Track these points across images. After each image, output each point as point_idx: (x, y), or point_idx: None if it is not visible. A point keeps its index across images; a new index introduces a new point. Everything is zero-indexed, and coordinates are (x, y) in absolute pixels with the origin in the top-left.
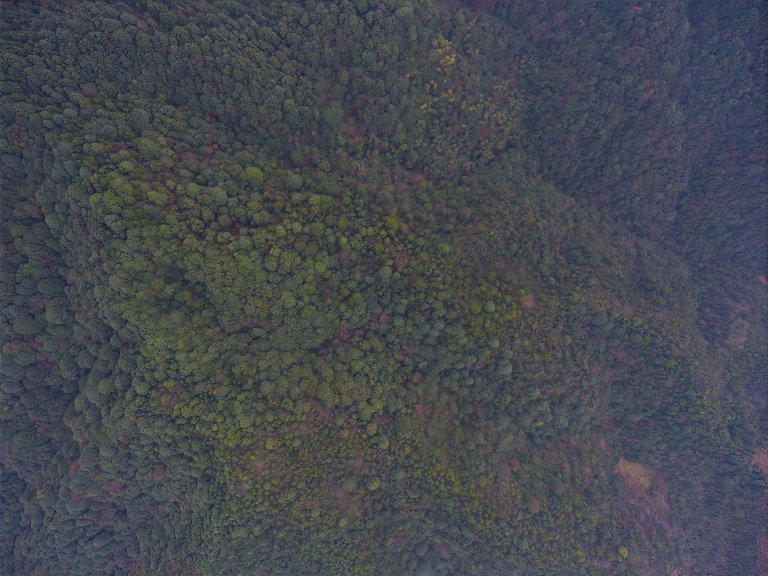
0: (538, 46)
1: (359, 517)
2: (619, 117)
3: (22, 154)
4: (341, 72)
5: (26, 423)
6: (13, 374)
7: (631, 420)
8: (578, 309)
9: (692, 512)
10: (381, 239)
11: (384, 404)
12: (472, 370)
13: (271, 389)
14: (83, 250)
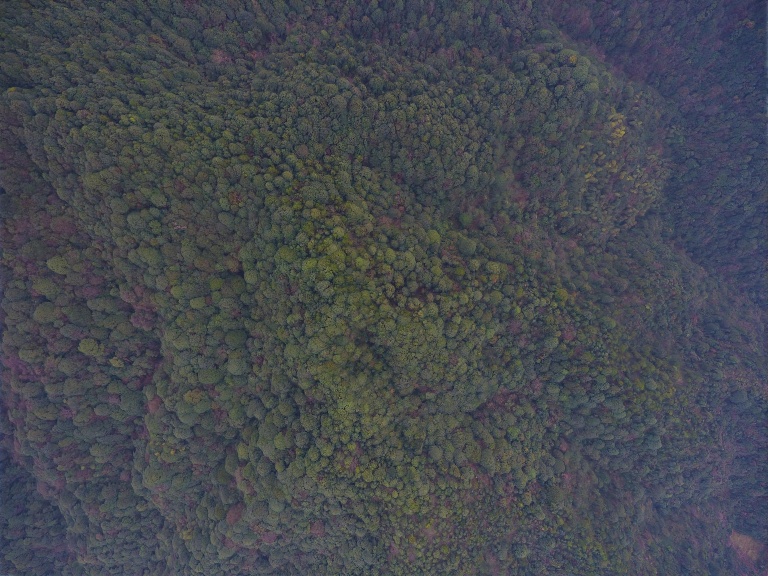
0: (685, 116)
1: None
2: None
3: (237, 212)
4: (518, 139)
5: (185, 466)
6: (190, 422)
7: (750, 495)
8: (721, 386)
9: None
10: (552, 310)
11: (537, 473)
12: (617, 442)
13: (441, 455)
14: (281, 309)
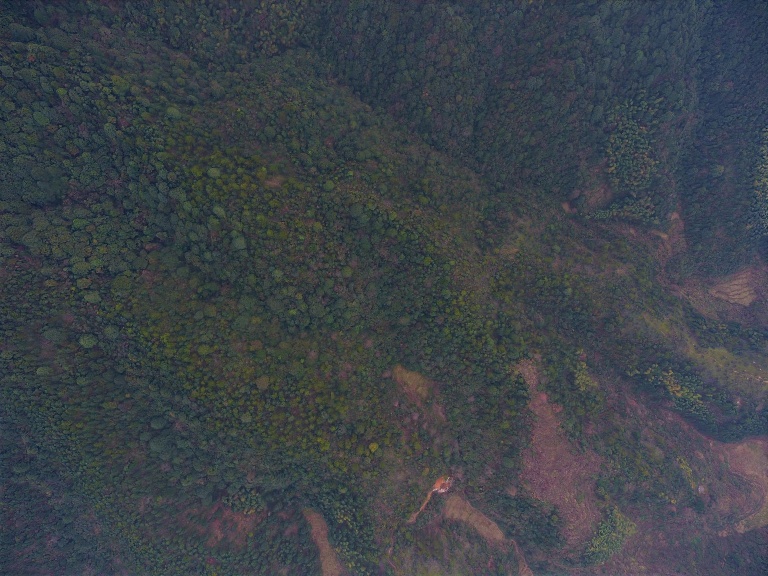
0: None
1: (68, 372)
2: (396, 16)
3: None
4: None
5: None
6: None
7: (401, 323)
8: (330, 196)
9: (466, 424)
10: (104, 96)
11: (104, 263)
12: (210, 244)
13: None
14: None
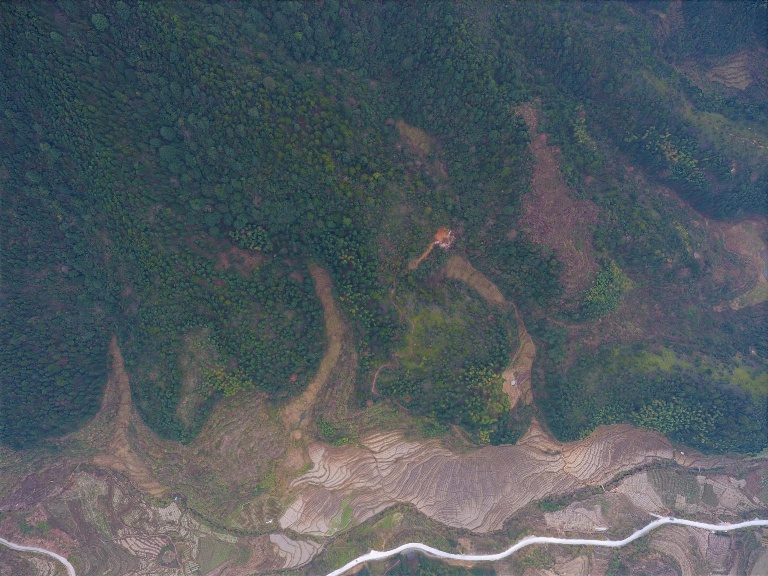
0: None
1: (81, 48)
2: None
3: None
4: None
5: None
6: None
7: (404, 67)
8: None
9: (467, 179)
10: None
11: None
12: None
13: None
14: None
